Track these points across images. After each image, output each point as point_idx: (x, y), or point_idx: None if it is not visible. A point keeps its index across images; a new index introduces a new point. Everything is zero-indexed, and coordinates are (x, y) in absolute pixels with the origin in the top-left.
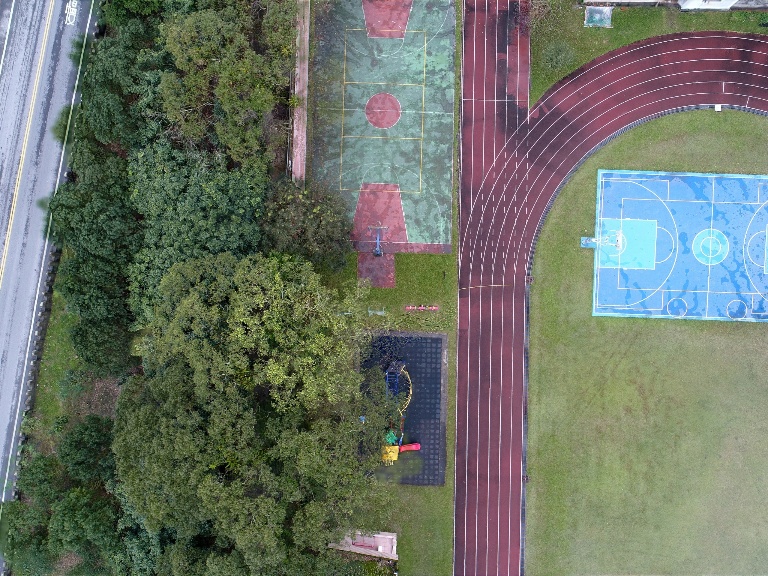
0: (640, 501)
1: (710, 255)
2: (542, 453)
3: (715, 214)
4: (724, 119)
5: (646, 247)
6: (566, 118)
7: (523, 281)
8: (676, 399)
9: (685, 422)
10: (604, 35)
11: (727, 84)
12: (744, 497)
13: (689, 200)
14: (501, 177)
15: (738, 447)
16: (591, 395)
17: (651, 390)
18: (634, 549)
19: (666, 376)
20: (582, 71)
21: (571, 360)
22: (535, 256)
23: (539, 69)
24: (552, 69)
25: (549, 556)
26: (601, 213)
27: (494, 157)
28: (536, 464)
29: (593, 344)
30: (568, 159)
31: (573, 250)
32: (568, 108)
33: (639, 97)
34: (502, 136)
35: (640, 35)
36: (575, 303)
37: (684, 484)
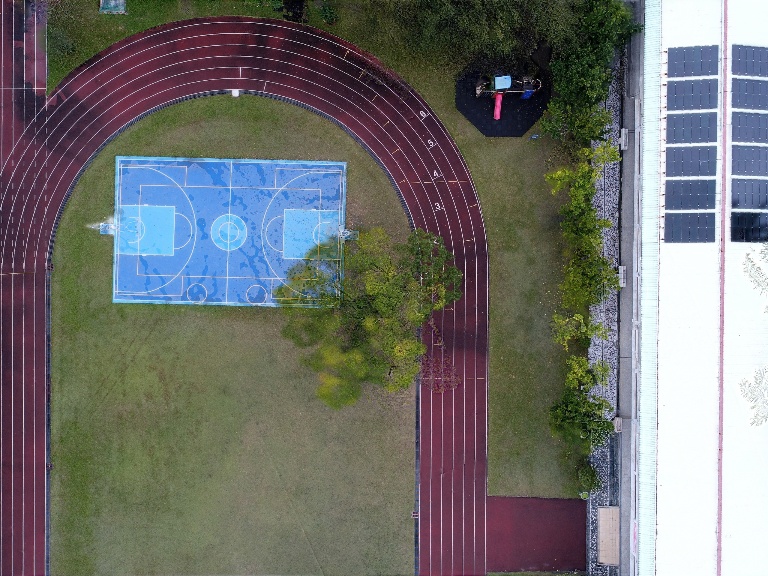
0: (162, 487)
1: (228, 240)
2: (64, 440)
3: (233, 199)
4: (241, 104)
5: (164, 233)
6: (84, 105)
7: (44, 269)
8: (197, 385)
9: (206, 408)
10: (120, 22)
11: (244, 69)
12: (266, 482)
13: (207, 186)
14: (20, 165)
15: (259, 432)
16: (112, 382)
17: (172, 376)
18: (157, 535)
19: (186, 362)
20: (99, 58)
21: (92, 347)
22: (55, 243)
23: (55, 56)
24: (69, 56)
25: (73, 543)
26: (120, 200)
27: (13, 145)
28: (59, 451)
29: (114, 331)
30: (87, 146)
31: (92, 237)
32: (86, 95)
33: (156, 83)
34: (20, 124)
35: (156, 21)
36: (95, 290)
37: (206, 469)
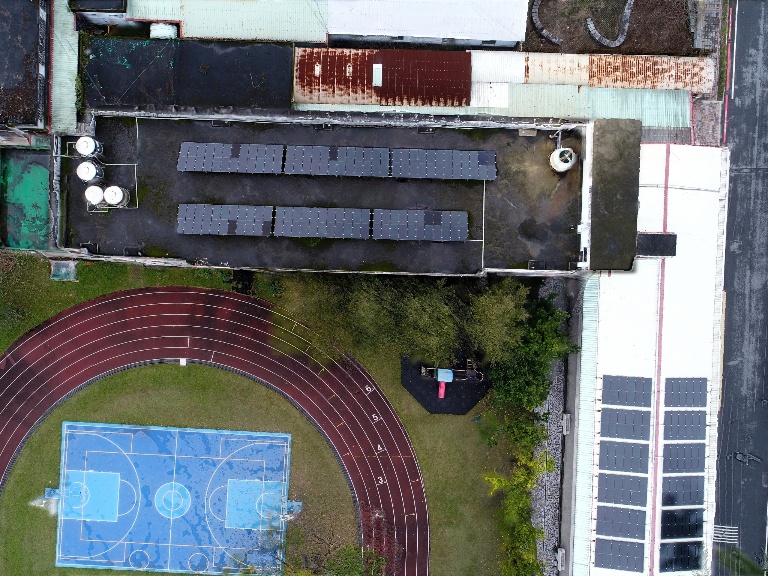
0: None
1: (172, 508)
2: None
3: (177, 468)
4: (188, 374)
5: (109, 499)
6: (33, 370)
7: None
8: None
9: None
10: (71, 288)
11: (192, 339)
12: None
13: (152, 454)
14: None
15: None
16: None
17: None
18: None
19: None
20: (49, 323)
21: None
22: (0, 506)
23: (6, 321)
24: (19, 321)
25: None
26: (65, 465)
27: None
28: None
29: None
30: (34, 410)
31: (37, 501)
32: (35, 360)
33: (105, 350)
34: None
35: (106, 289)
36: (39, 553)
37: None
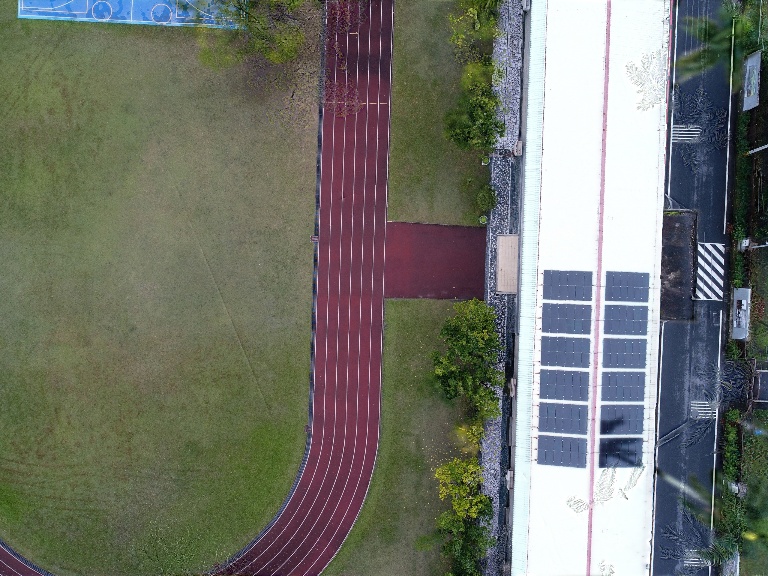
0: (62, 204)
1: None
2: None
3: None
4: None
5: None
6: None
7: None
8: (99, 102)
9: (108, 125)
10: None
11: None
12: (166, 201)
13: None
14: None
15: (160, 151)
16: (15, 97)
17: (74, 93)
18: (56, 252)
19: (89, 79)
20: None
21: None
22: None
23: None
24: None
25: None
26: None
27: None
28: None
29: (18, 46)
30: None
31: None
32: None
33: None
34: None
35: None
36: (1, 5)
37: (106, 187)
